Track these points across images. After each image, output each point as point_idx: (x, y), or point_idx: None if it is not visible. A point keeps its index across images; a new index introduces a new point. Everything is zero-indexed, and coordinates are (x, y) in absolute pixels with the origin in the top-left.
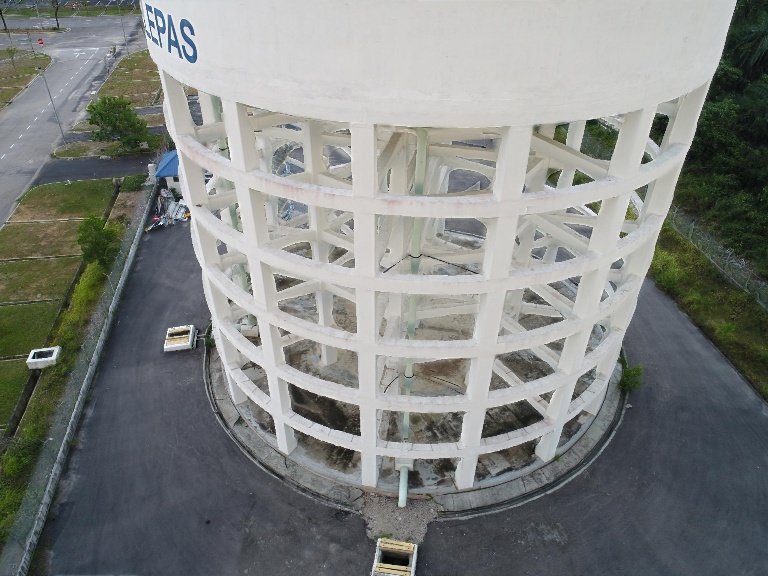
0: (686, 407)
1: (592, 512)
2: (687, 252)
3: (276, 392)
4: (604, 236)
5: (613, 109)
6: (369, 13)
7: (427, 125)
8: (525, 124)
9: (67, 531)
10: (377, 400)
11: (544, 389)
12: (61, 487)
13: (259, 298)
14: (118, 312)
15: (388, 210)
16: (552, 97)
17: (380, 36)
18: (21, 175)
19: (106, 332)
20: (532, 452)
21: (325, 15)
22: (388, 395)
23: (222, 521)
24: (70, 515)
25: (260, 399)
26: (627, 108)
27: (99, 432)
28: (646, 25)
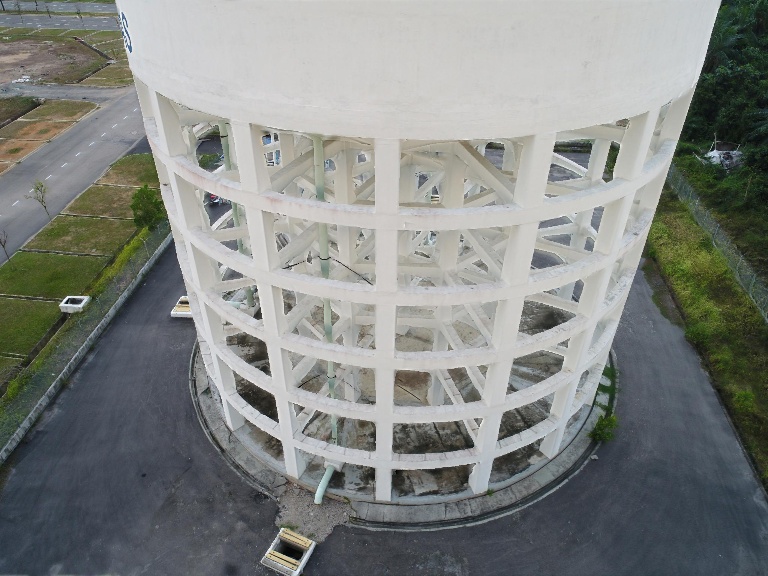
0: (661, 472)
1: (506, 556)
2: (741, 306)
3: (217, 368)
4: (510, 266)
5: (492, 132)
6: (233, 16)
7: (294, 129)
8: (390, 138)
9: (32, 455)
10: (288, 393)
11: (458, 416)
12: (43, 417)
13: (195, 277)
14: (148, 275)
15: (272, 208)
16: (416, 113)
17: (244, 39)
18: (122, 144)
19: (131, 291)
20: (466, 481)
21: (200, 15)
22: (300, 390)
23: (156, 477)
24: (40, 442)
25: (211, 373)
26: (512, 132)
27: (91, 376)
28: (522, 46)
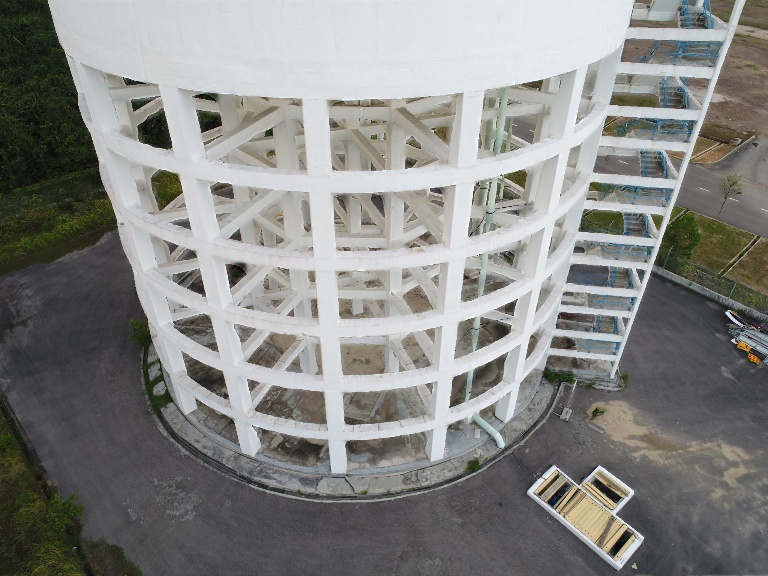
0: (89, 352)
1: None
2: None
3: None
4: None
5: None
6: None
7: None
8: None
9: None
10: None
11: None
12: None
13: None
14: None
15: None
16: None
17: None
18: None
19: None
20: None
21: None
22: None
23: None
24: None
25: None
26: None
27: None
28: None
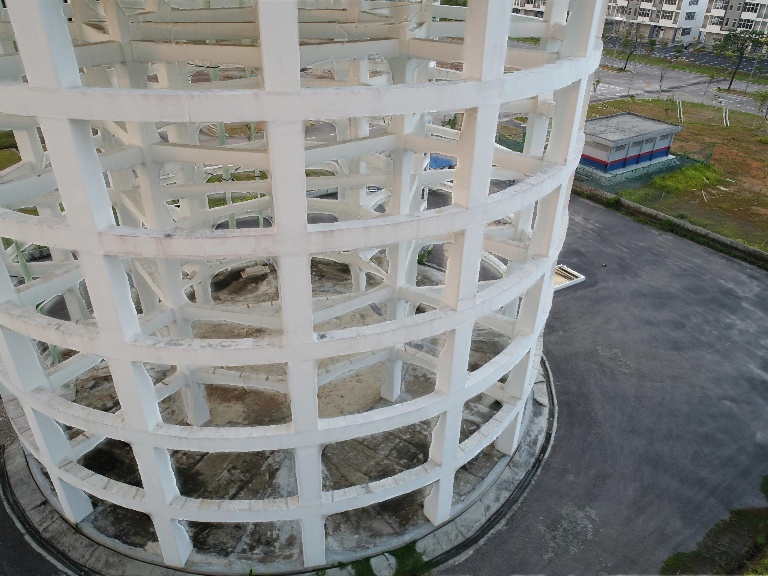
0: None
1: None
2: None
3: None
4: None
5: None
6: None
7: None
8: None
9: None
10: None
11: None
12: None
13: None
14: None
15: None
16: None
17: None
18: None
19: None
20: None
21: None
22: None
23: None
24: None
25: None
26: None
27: None
28: None
